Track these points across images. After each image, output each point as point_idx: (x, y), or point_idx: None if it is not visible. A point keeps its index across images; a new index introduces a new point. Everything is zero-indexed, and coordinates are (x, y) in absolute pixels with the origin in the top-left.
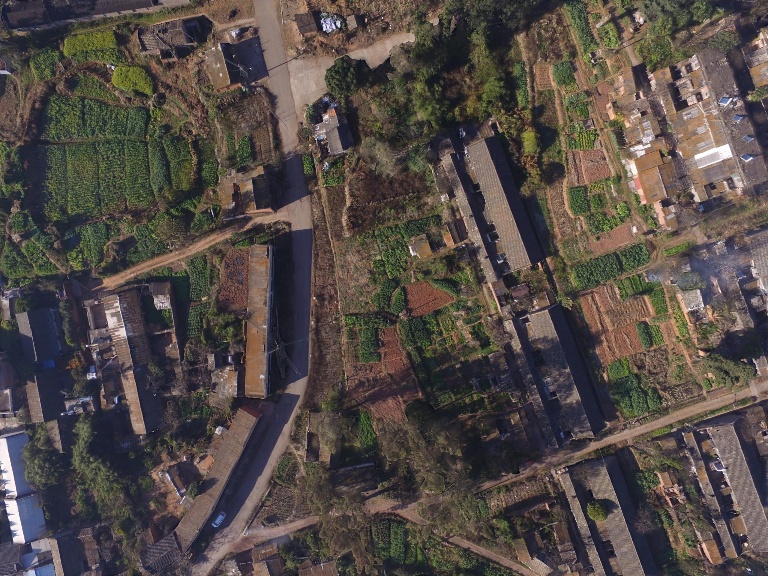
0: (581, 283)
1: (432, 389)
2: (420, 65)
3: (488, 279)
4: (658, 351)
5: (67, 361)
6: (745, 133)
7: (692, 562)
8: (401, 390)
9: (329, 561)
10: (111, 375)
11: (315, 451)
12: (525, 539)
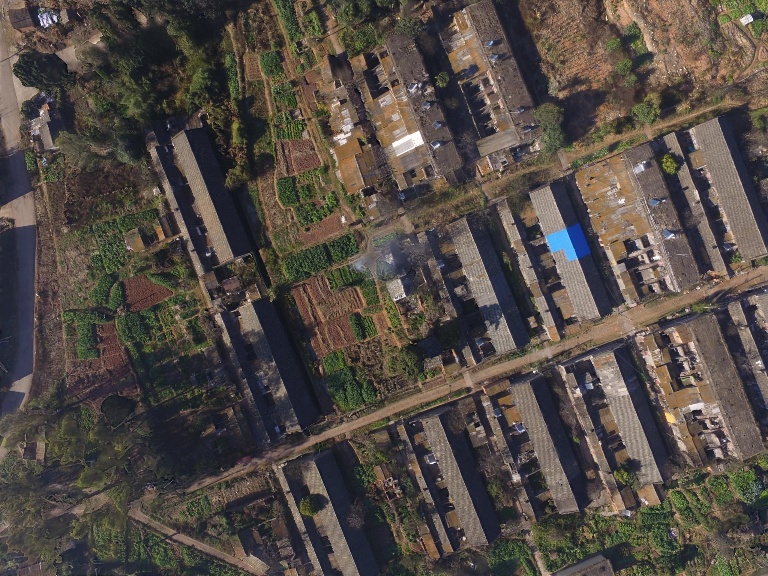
0: (290, 275)
1: (152, 385)
2: (116, 57)
3: (197, 272)
4: (372, 343)
5: None
6: (435, 119)
7: (417, 557)
8: (120, 386)
9: None
10: None
11: (33, 449)
12: (239, 535)
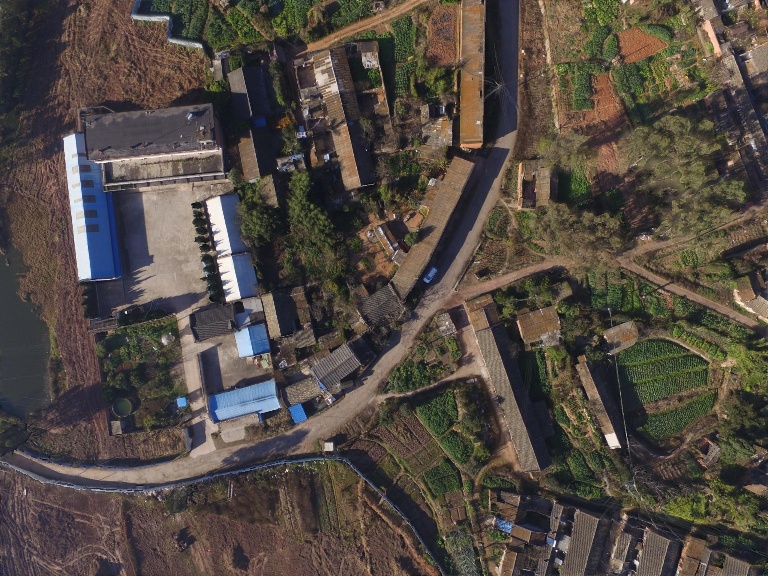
0: None
1: None
2: None
3: (707, 16)
4: None
5: (277, 121)
6: None
7: None
8: (615, 137)
9: (548, 306)
10: (321, 133)
11: (531, 198)
12: (749, 276)
